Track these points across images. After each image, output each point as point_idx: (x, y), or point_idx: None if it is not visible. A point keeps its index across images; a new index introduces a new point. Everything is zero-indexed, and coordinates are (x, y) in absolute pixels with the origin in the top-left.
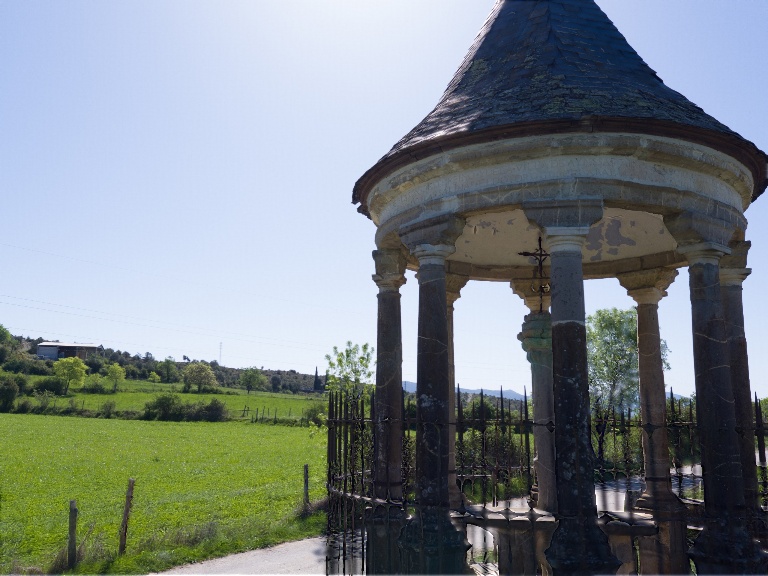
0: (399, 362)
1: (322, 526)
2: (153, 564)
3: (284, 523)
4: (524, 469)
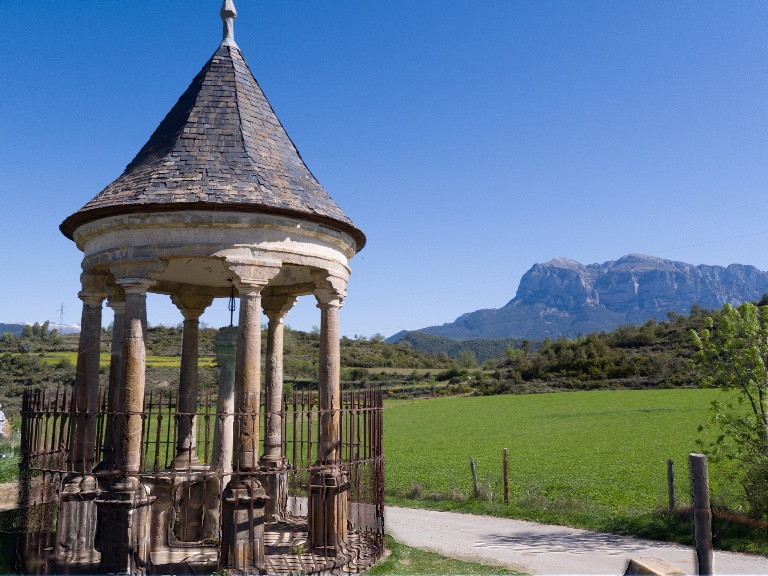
0: None
1: (627, 526)
2: (482, 509)
3: (636, 518)
4: None
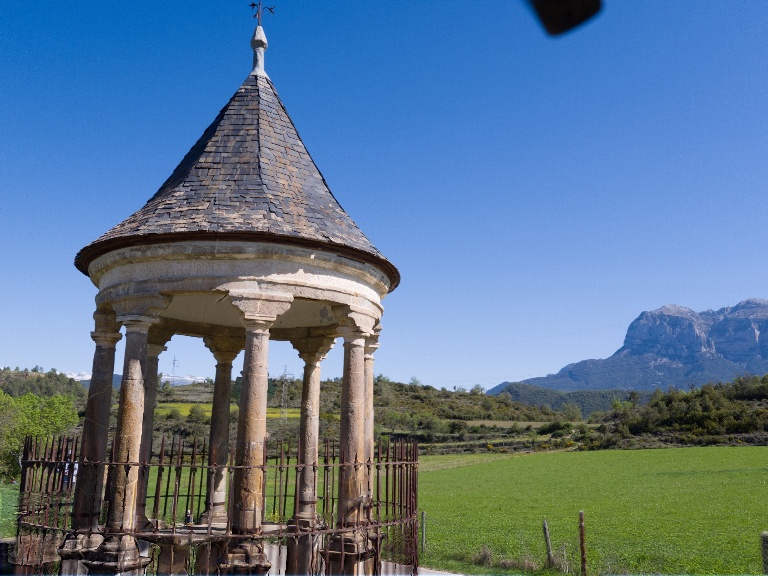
0: (302, 416)
1: None
2: None
3: None
4: None
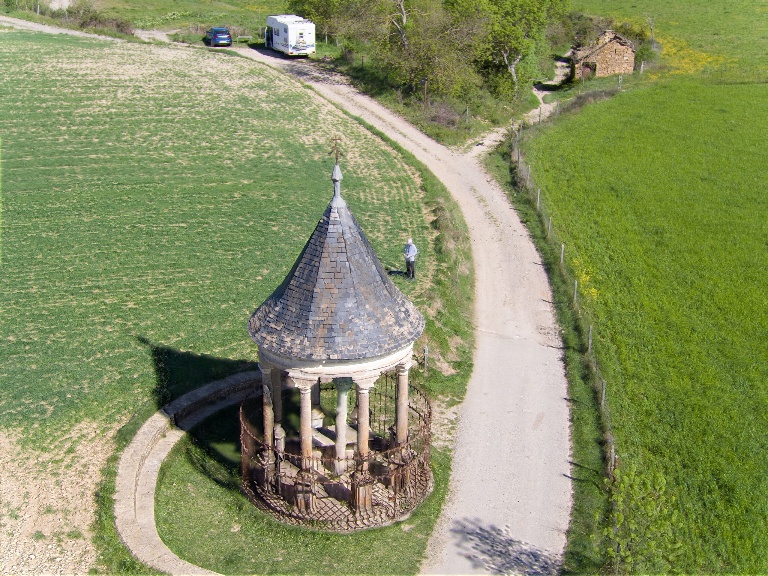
0: None
1: None
2: None
3: None
4: (381, 477)
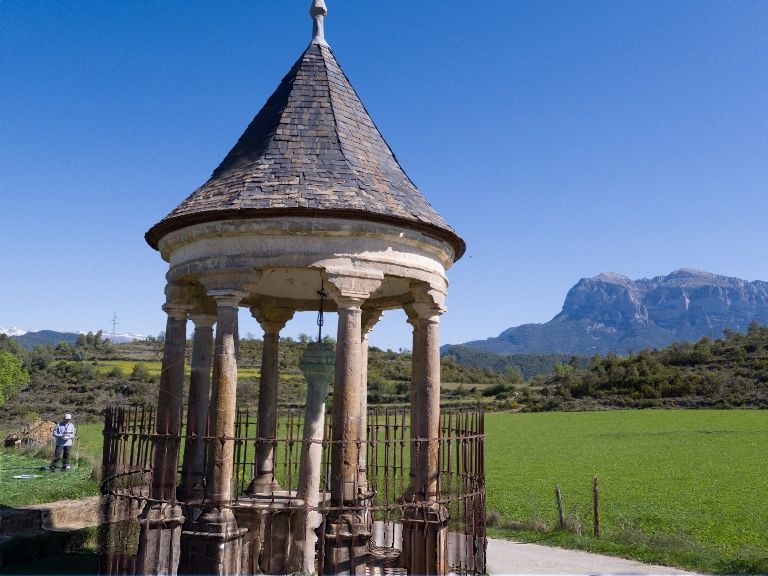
0: None
1: (748, 571)
2: None
3: (754, 561)
4: None
